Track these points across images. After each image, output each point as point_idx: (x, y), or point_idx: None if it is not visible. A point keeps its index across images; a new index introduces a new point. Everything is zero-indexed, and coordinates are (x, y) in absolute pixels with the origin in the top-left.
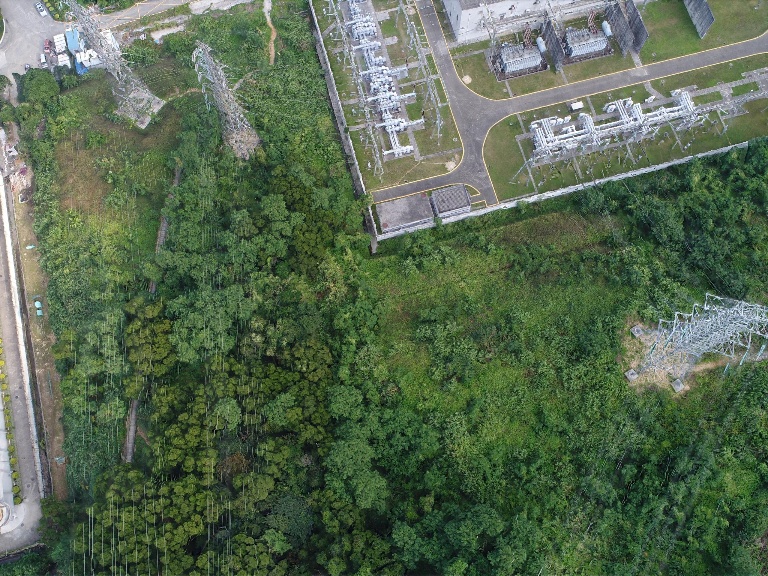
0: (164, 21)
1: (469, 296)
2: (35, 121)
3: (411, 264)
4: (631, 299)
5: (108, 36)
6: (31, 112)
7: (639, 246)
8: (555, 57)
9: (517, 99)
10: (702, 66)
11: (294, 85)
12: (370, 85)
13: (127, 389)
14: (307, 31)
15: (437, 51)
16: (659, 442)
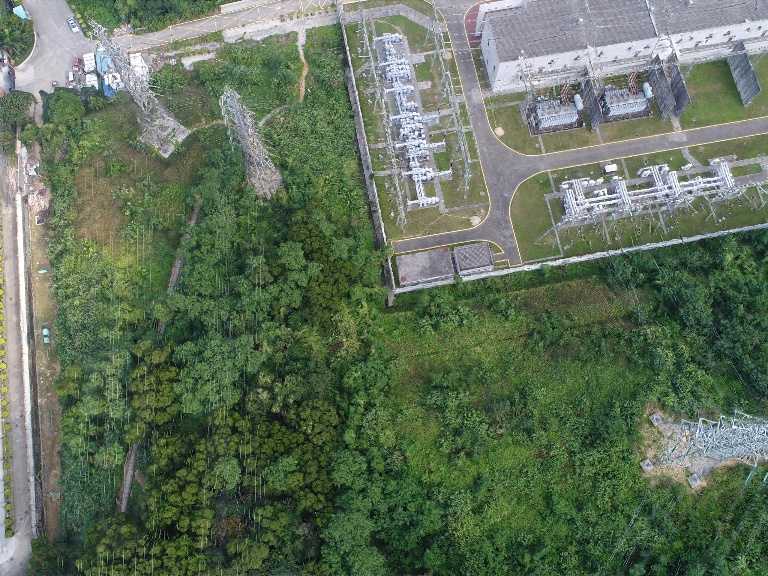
0: (196, 47)
1: (484, 363)
2: (58, 143)
3: (427, 324)
4: (652, 384)
5: (138, 59)
6: (54, 133)
7: (665, 326)
8: (592, 115)
9: (549, 156)
10: (743, 135)
11: (322, 125)
12: (399, 131)
13: (127, 435)
14: (340, 69)
15: (471, 99)
16: (671, 541)
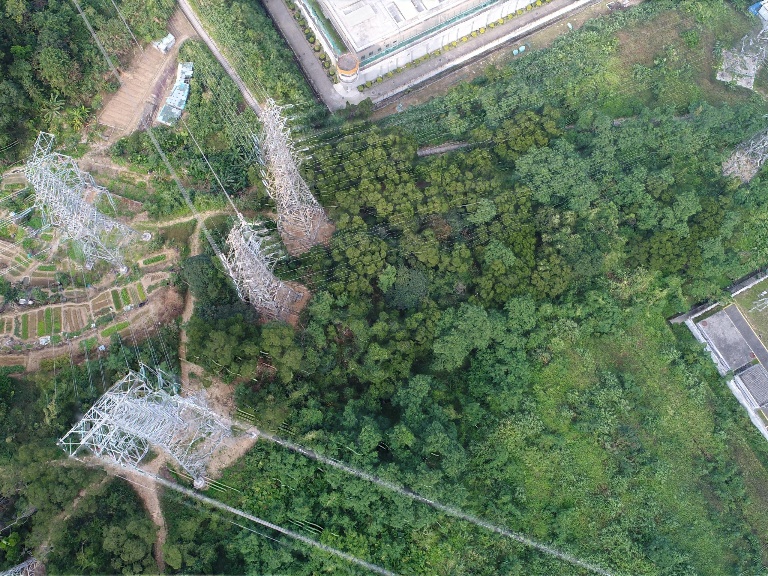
0: None
1: (662, 419)
2: None
3: (674, 355)
4: None
5: None
6: None
7: None
8: None
9: None
10: None
11: None
12: None
13: (477, 129)
14: None
15: None
16: None
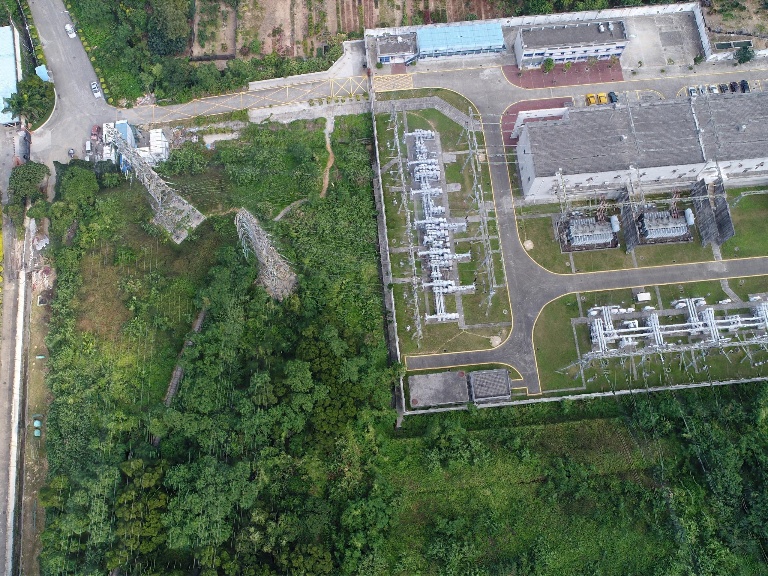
0: (219, 124)
1: (493, 511)
2: (67, 222)
3: (435, 458)
4: (672, 559)
5: (158, 136)
6: (65, 211)
7: (689, 490)
8: (628, 237)
9: (579, 276)
10: None
11: (343, 225)
12: (424, 237)
13: (109, 563)
14: (366, 164)
15: (501, 207)
16: None
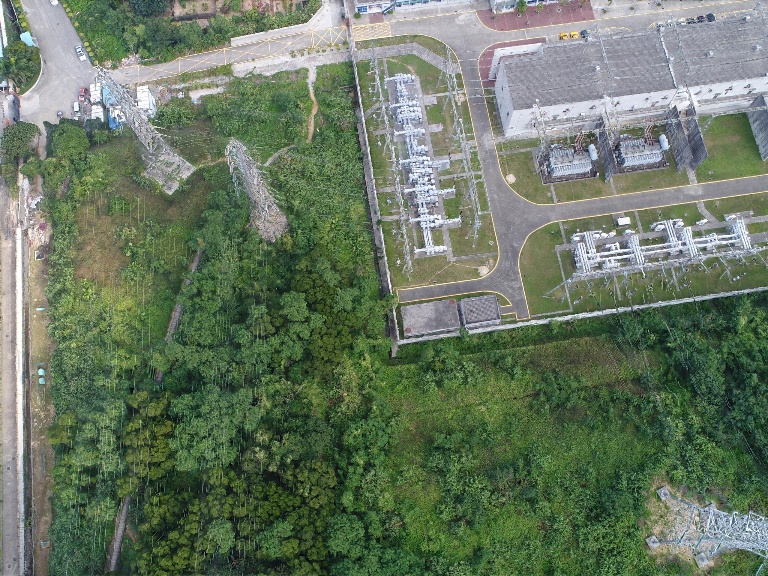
0: (204, 80)
1: (488, 425)
2: (60, 177)
3: (431, 380)
4: (661, 455)
5: (145, 92)
6: (57, 167)
7: (675, 393)
8: (606, 166)
9: (561, 206)
10: (761, 191)
11: (330, 167)
12: (409, 175)
13: (120, 490)
14: (350, 109)
15: (483, 144)
16: None
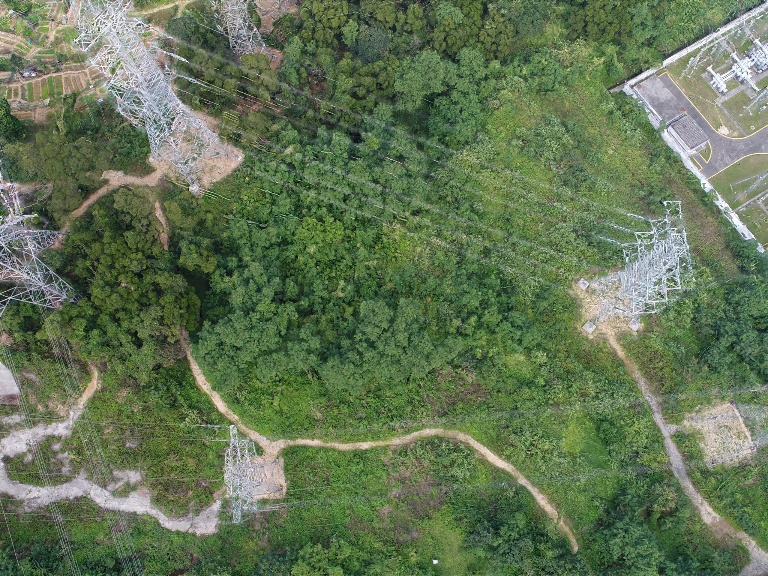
0: None
1: None
2: None
3: (612, 106)
4: None
5: None
6: None
7: None
8: None
9: None
10: None
11: None
12: None
13: None
14: None
15: None
16: None
